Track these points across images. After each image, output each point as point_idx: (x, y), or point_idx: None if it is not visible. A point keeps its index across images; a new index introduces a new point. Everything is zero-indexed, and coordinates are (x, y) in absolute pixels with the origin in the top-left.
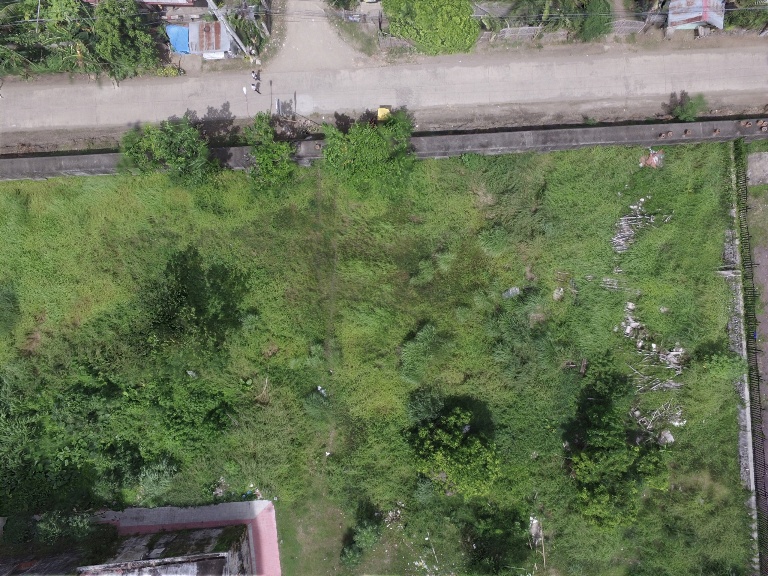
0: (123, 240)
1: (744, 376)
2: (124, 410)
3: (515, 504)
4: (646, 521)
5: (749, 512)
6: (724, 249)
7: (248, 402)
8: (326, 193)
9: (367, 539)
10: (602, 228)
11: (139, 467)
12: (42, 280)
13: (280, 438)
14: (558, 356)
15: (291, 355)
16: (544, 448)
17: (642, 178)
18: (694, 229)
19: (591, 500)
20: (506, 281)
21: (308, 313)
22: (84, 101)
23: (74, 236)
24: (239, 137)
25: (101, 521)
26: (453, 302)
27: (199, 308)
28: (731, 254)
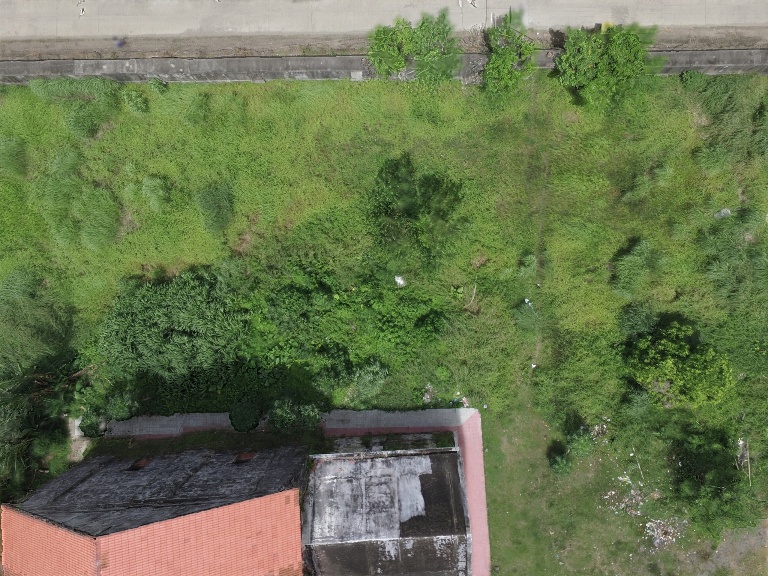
0: (335, 146)
1: None
2: (334, 313)
3: (722, 424)
4: None
5: None
6: None
7: (458, 310)
8: (540, 107)
9: (583, 447)
10: None
11: (351, 368)
12: (256, 181)
13: (493, 345)
14: None
15: (501, 266)
16: (753, 369)
17: None
18: None
19: None
20: (719, 202)
21: (519, 225)
22: (300, 8)
23: (289, 139)
24: (455, 48)
25: None
26: (664, 221)
27: (410, 216)
28: None
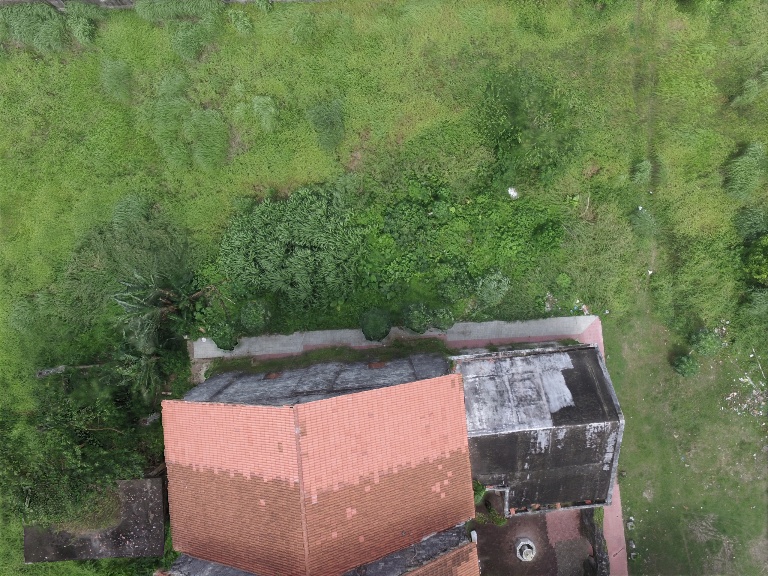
0: (443, 61)
1: None
2: (450, 226)
3: None
4: None
5: None
6: None
7: (575, 218)
8: (646, 16)
9: (710, 345)
10: None
11: (473, 278)
12: (366, 98)
13: (613, 251)
14: None
15: (615, 174)
16: None
17: None
18: None
19: None
20: None
21: (630, 134)
22: None
23: (397, 55)
24: None
25: (428, 335)
26: None
27: None
28: None
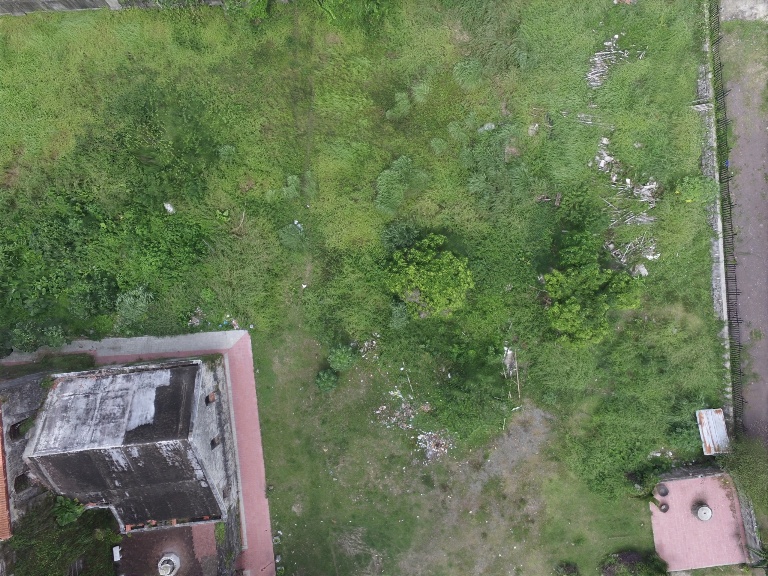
0: (102, 77)
1: (717, 208)
2: (102, 242)
3: (490, 334)
4: (620, 350)
5: (722, 342)
6: (698, 85)
7: (225, 233)
8: (303, 30)
9: (341, 360)
10: (576, 63)
11: (116, 294)
12: (21, 114)
13: (256, 265)
14: (532, 186)
15: (268, 188)
16: (519, 279)
17: (616, 14)
18: (667, 64)
19: (562, 310)
20: (481, 116)
21: (285, 148)
22: None
23: (53, 71)
24: None
25: (78, 351)
26: (429, 137)
27: (177, 143)
28: (704, 89)
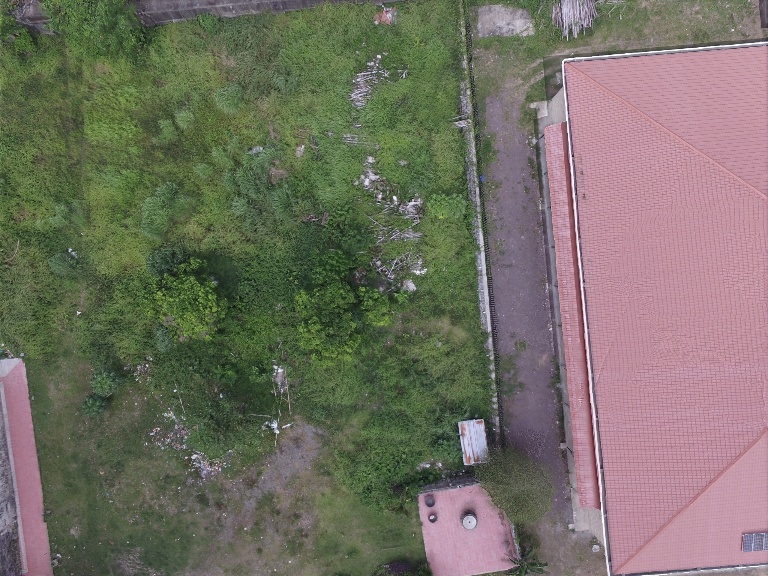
0: None
1: (478, 222)
2: None
3: (260, 354)
4: (386, 365)
5: (487, 353)
6: (460, 102)
7: None
8: (72, 61)
9: (103, 385)
10: (338, 84)
11: None
12: None
13: (24, 295)
14: (294, 207)
15: (40, 218)
16: (287, 299)
17: (376, 34)
18: (427, 82)
19: (303, 330)
20: (248, 139)
21: (57, 177)
22: None
23: None
24: None
25: None
26: (198, 162)
27: None
28: (465, 105)
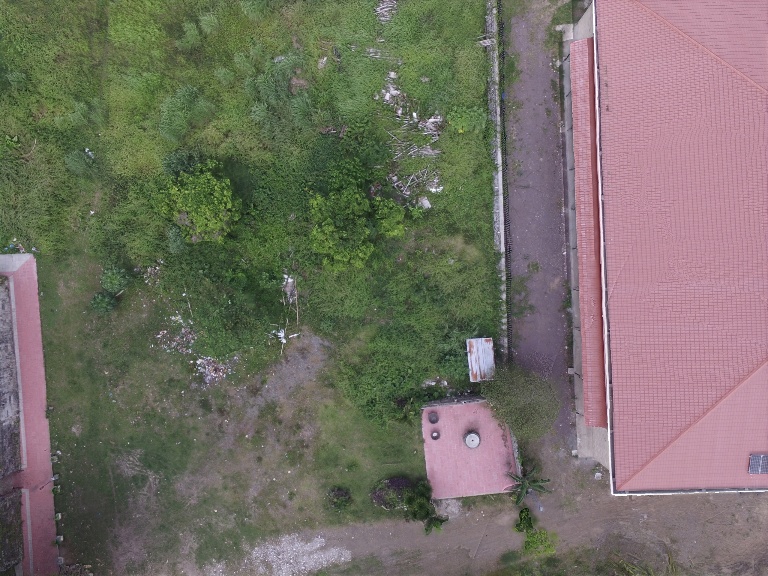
0: None
1: (497, 141)
2: None
3: (270, 262)
4: (397, 280)
5: (499, 274)
6: (485, 22)
7: (13, 158)
8: None
9: (113, 280)
10: None
11: None
12: None
13: (39, 189)
14: (313, 116)
15: None
16: (301, 209)
17: None
18: None
19: None
20: (270, 48)
21: (78, 77)
22: None
23: None
24: None
25: None
26: None
27: None
28: (490, 25)
